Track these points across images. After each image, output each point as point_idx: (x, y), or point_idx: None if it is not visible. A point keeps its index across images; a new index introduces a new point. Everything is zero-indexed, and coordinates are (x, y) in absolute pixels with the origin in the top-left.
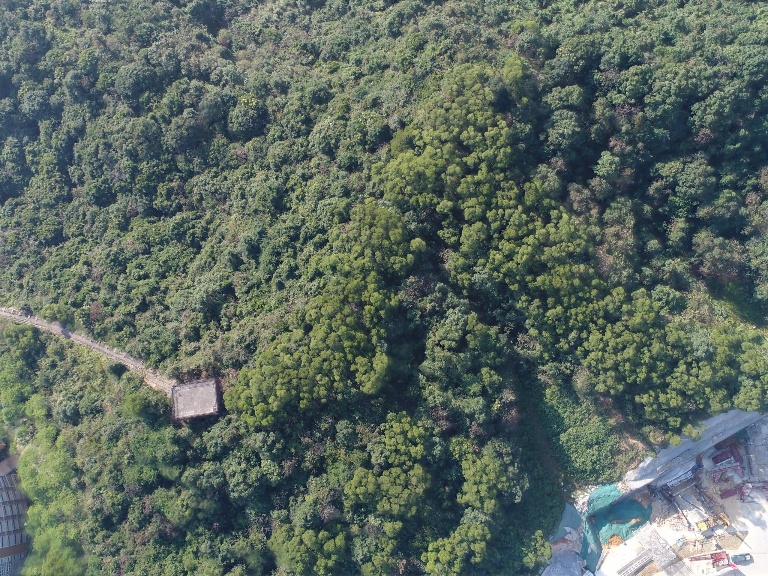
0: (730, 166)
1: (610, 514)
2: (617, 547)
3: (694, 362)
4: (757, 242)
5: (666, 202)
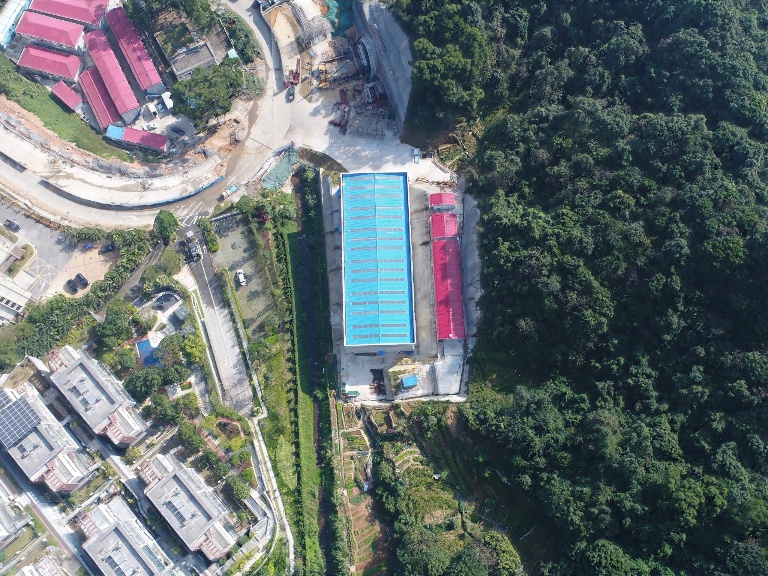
0: (634, 79)
1: (345, 8)
2: (320, 8)
3: (461, 6)
4: (559, 108)
5: (605, 43)
